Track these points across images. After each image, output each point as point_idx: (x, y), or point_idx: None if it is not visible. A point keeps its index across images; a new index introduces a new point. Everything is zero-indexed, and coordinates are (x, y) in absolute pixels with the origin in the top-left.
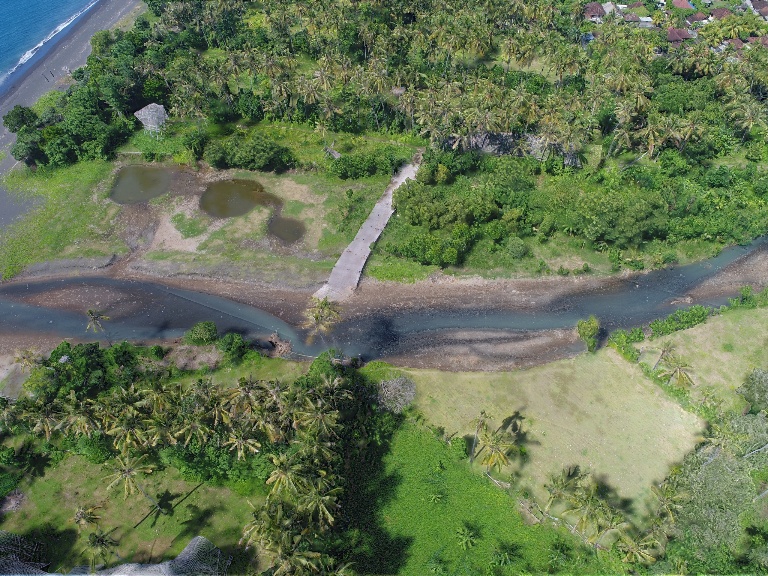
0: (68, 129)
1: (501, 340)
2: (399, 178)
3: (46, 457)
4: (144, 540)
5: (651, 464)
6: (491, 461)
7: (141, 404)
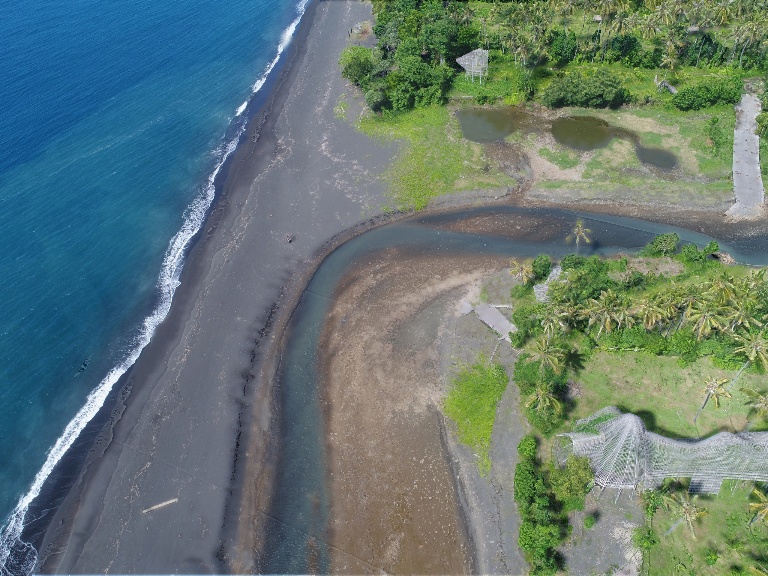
0: (406, 76)
1: None
2: (743, 107)
3: (576, 353)
4: (719, 418)
5: None
6: None
7: (708, 294)
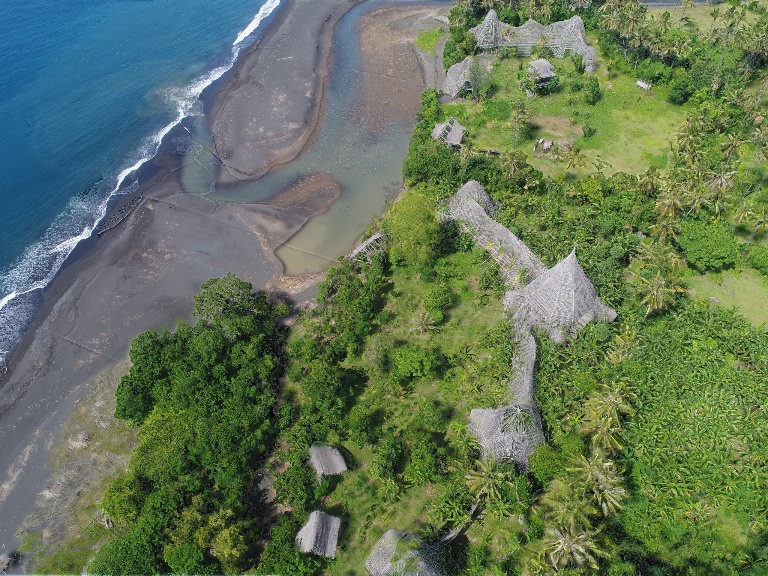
0: None
1: (669, 5)
2: None
3: None
4: None
5: None
6: (688, 4)
7: None
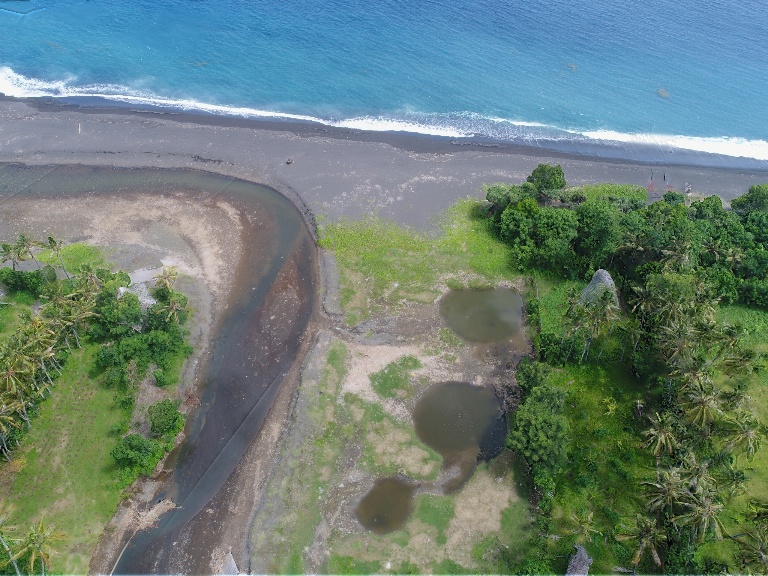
0: (541, 218)
1: None
2: None
3: None
4: None
5: None
6: None
7: None
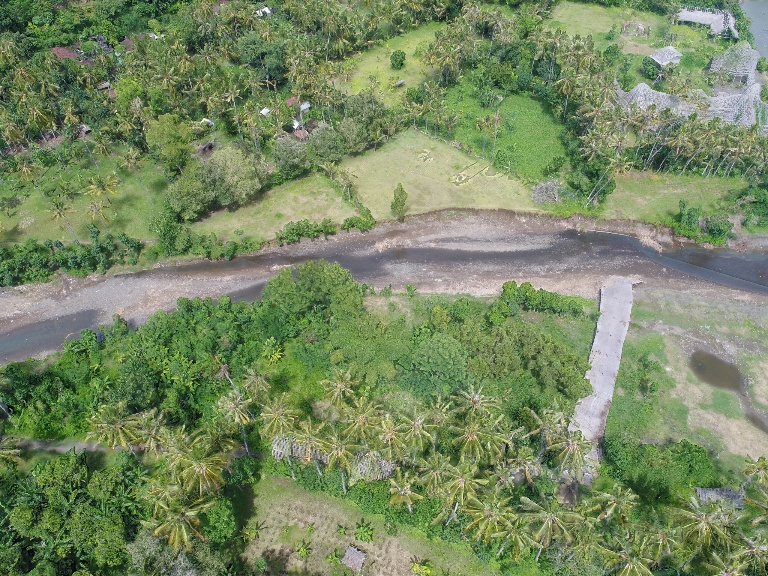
0: None
1: (459, 240)
2: None
3: None
4: None
5: (379, 161)
6: None
7: None
